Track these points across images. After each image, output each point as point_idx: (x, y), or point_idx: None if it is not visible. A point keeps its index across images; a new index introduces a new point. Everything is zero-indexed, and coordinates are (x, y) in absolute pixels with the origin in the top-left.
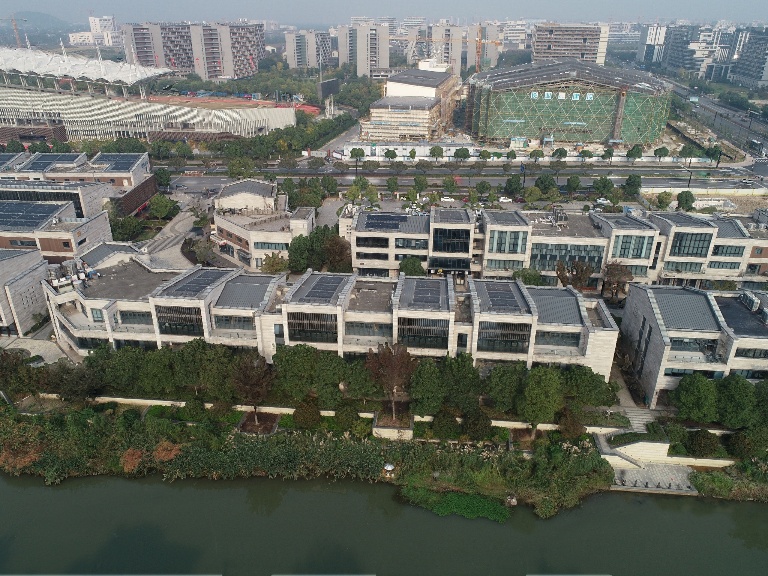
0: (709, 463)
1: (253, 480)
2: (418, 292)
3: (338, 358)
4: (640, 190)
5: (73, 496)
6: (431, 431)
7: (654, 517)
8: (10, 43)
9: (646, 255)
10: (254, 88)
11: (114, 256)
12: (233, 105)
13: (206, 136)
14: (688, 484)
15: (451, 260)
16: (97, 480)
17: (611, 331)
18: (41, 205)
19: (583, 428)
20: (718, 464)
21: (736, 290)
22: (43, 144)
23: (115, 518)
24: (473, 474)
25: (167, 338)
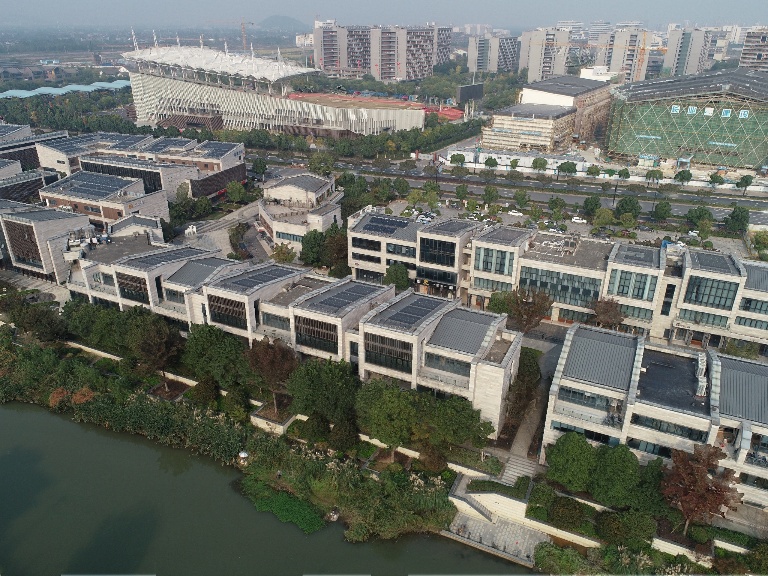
0: (573, 538)
1: (136, 437)
2: (338, 295)
3: (237, 344)
4: (755, 227)
5: (16, 416)
6: (299, 431)
7: (467, 575)
8: (191, 43)
9: (649, 297)
10: (412, 90)
11: (130, 227)
12: (386, 105)
13: (329, 132)
14: (530, 553)
15: (437, 272)
16: (35, 408)
17: (496, 367)
18: (120, 180)
19: (442, 464)
20: (583, 542)
21: (754, 355)
22: (193, 130)
23: (19, 440)
24: (313, 481)
25: (126, 302)
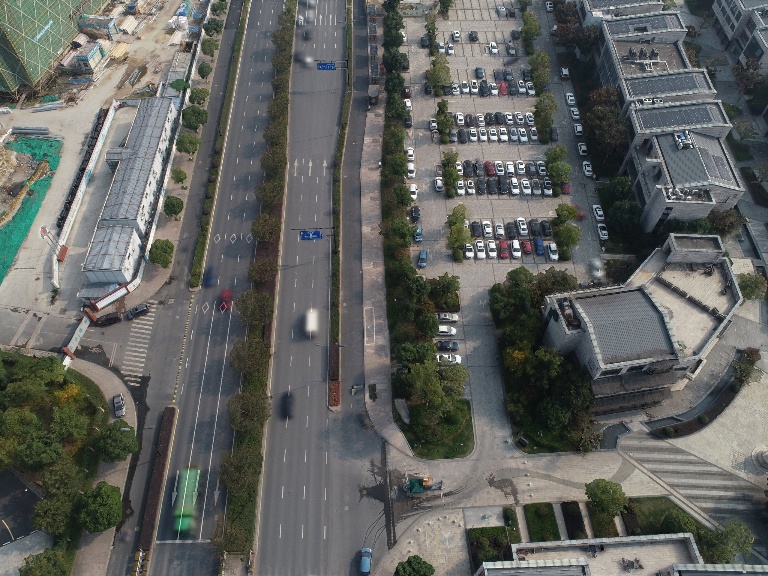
0: None
1: None
2: None
3: None
4: None
5: None
6: None
7: None
8: None
9: None
10: None
11: None
12: None
13: None
14: None
15: None
16: None
17: None
18: None
19: None
20: None
21: None
22: None
23: None
24: None
25: None
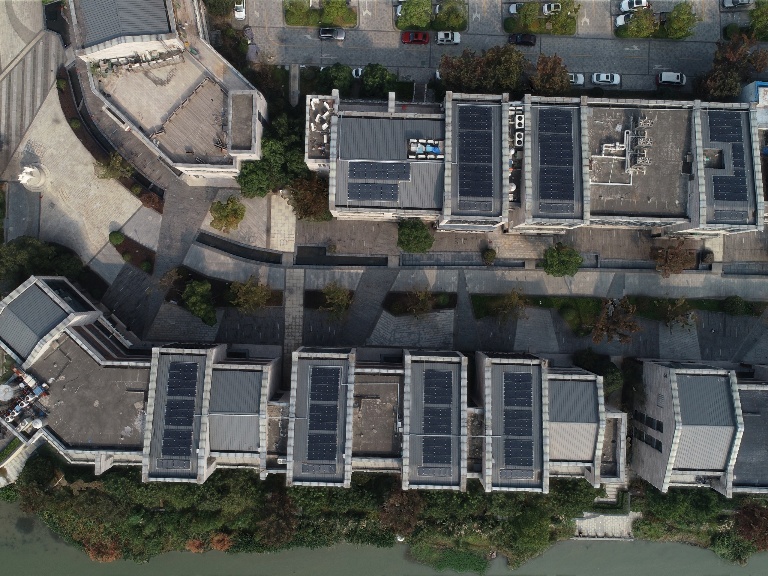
0: None
1: None
2: (428, 425)
3: (350, 495)
4: None
5: None
6: None
7: (593, 558)
8: None
9: None
10: None
11: (42, 348)
12: None
13: None
14: (630, 530)
15: None
16: None
17: None
18: None
19: None
20: None
21: None
22: None
23: None
24: None
25: None
